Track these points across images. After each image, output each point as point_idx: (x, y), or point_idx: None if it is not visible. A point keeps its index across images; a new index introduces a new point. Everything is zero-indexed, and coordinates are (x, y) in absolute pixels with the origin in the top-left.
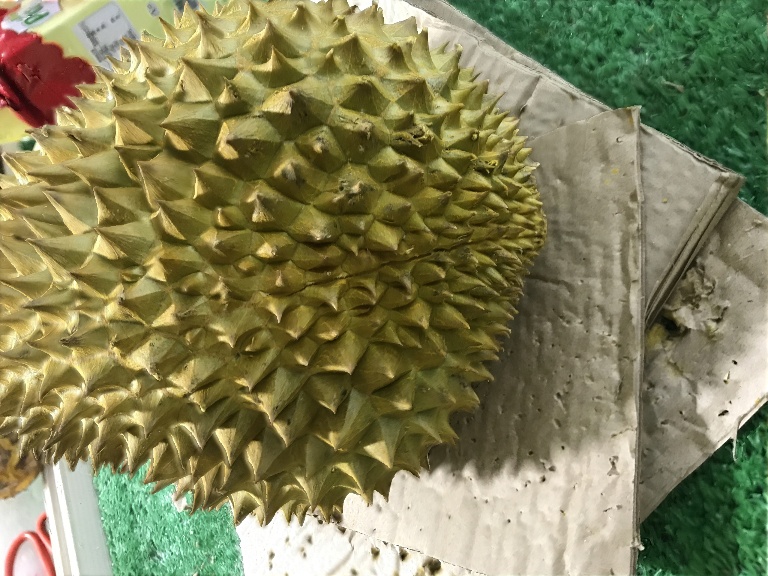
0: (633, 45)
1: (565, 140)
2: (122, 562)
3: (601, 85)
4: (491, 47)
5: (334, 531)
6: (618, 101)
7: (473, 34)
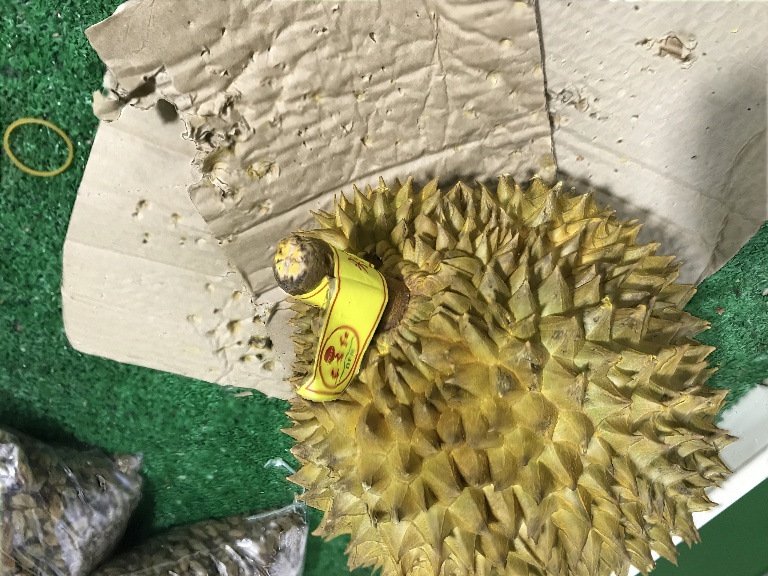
0: None
1: None
2: None
3: None
4: None
5: (225, 258)
6: None
7: None
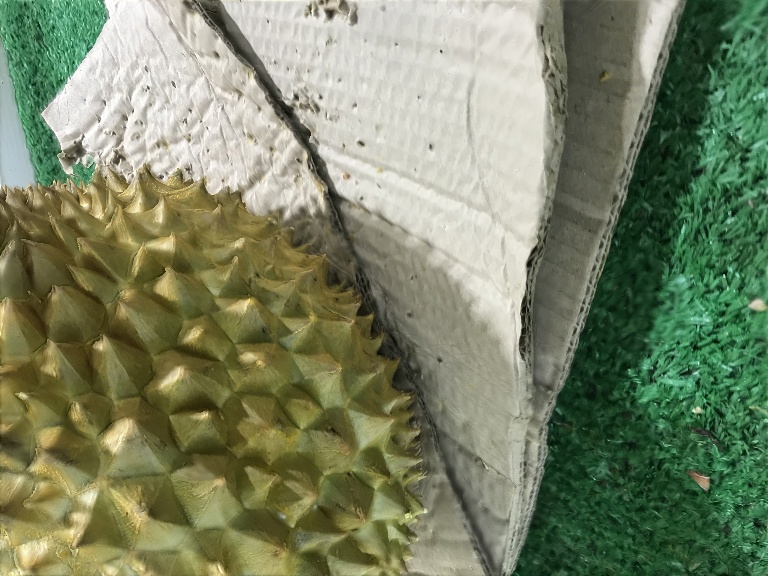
0: (595, 545)
1: (458, 539)
2: (3, 15)
3: (549, 516)
4: (527, 420)
5: None
6: (539, 533)
7: (527, 404)
